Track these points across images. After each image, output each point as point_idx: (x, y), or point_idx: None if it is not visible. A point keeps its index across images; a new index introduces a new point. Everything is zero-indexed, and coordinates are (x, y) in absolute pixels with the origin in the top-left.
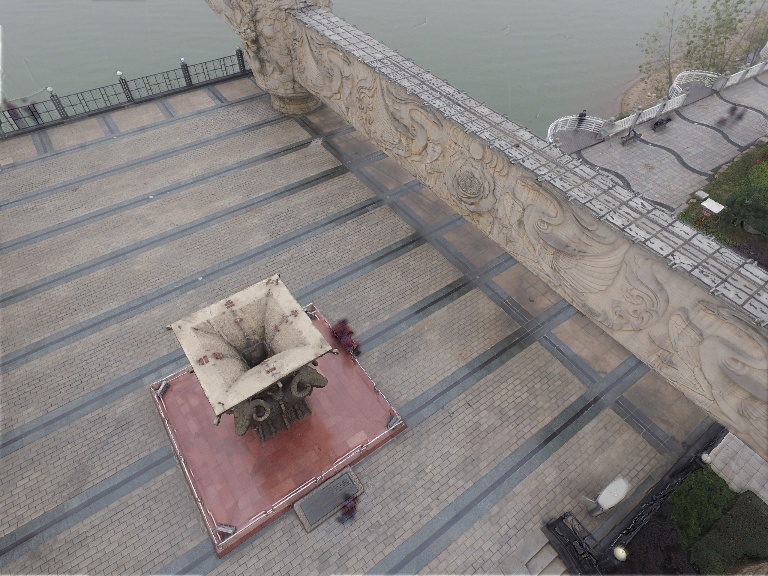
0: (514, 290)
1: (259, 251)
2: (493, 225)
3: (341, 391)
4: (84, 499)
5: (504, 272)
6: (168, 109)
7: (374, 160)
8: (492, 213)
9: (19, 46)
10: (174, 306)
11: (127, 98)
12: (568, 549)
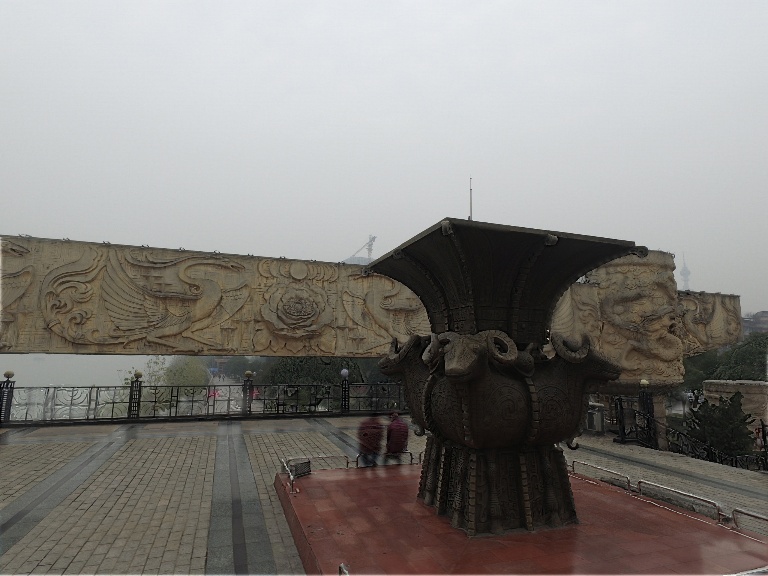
0: (359, 424)
1: (15, 512)
2: (336, 338)
3: None
4: None
5: (332, 423)
6: None
7: (17, 435)
8: (333, 324)
9: None
10: None
11: None
12: (640, 438)
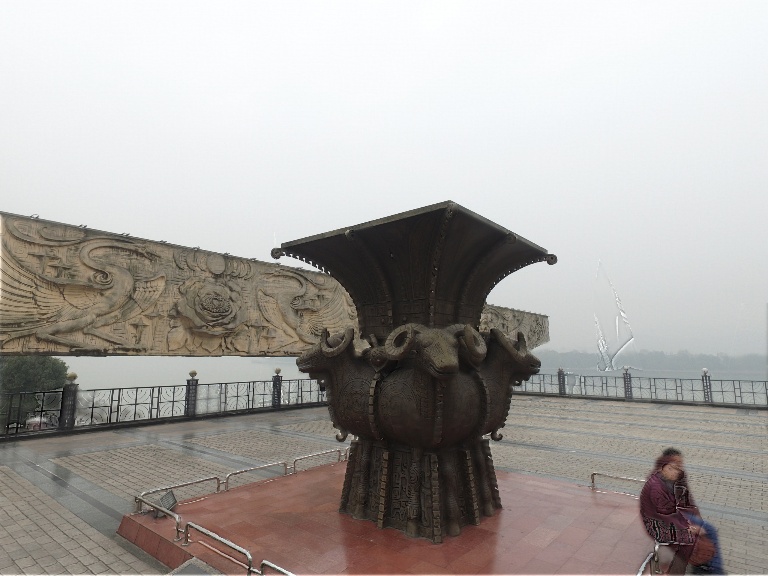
0: None
1: (695, 467)
2: None
3: (535, 571)
4: (240, 459)
5: None
6: (749, 412)
7: None
8: None
9: (643, 367)
10: (511, 449)
11: (705, 398)
12: None
